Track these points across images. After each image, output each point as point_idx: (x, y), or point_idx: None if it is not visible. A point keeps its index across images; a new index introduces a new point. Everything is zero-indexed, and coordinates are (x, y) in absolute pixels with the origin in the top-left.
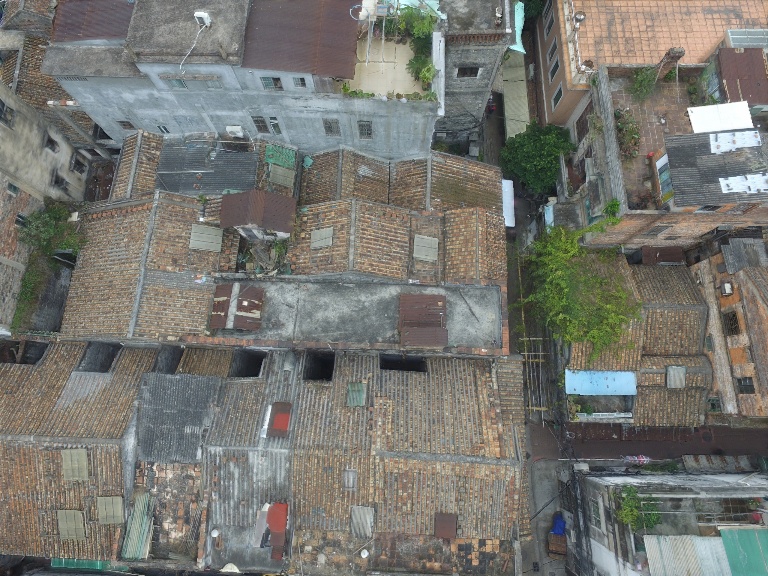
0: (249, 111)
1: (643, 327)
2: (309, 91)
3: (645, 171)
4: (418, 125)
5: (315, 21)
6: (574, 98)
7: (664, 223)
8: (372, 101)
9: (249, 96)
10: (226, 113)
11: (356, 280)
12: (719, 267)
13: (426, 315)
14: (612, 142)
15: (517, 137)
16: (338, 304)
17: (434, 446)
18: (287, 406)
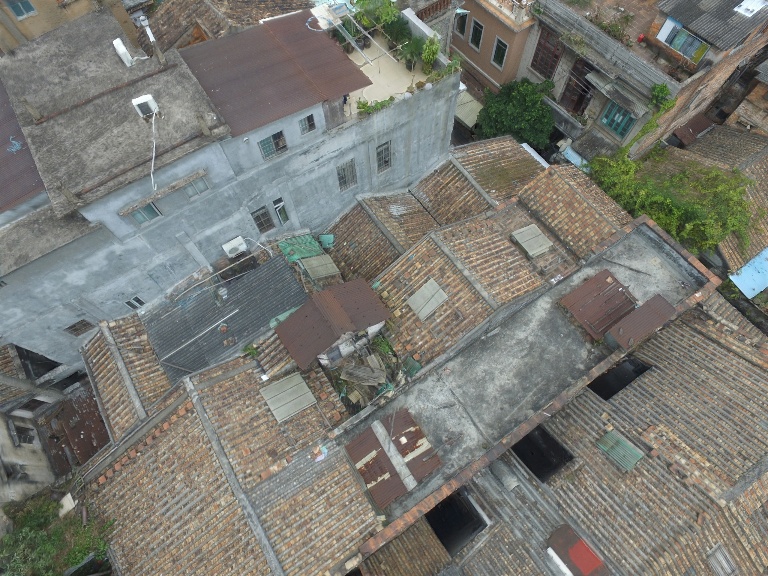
0: (247, 206)
1: (759, 188)
2: (319, 133)
3: (648, 53)
4: (439, 117)
5: (278, 52)
6: (520, 42)
7: (703, 84)
8: (392, 108)
9: (246, 181)
10: (218, 227)
11: (502, 319)
12: (767, 97)
13: (607, 302)
14: (607, 42)
15: (488, 109)
16: (501, 362)
17: (764, 438)
18: (567, 531)
